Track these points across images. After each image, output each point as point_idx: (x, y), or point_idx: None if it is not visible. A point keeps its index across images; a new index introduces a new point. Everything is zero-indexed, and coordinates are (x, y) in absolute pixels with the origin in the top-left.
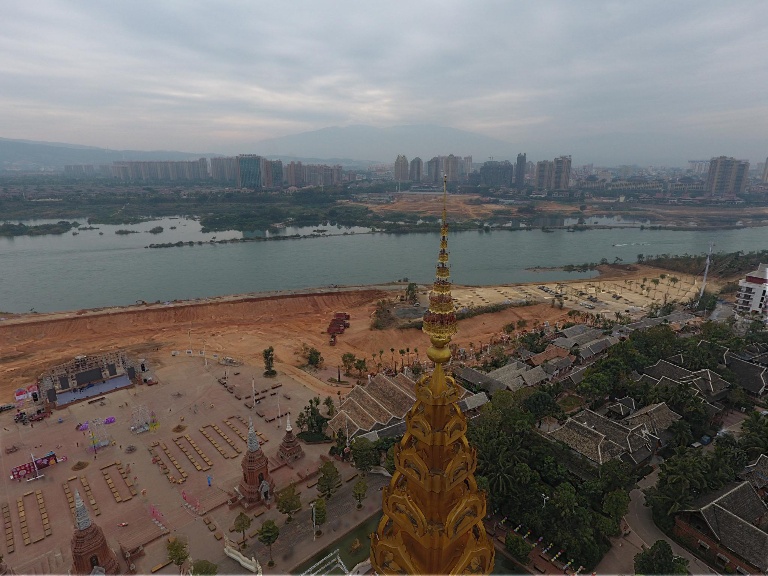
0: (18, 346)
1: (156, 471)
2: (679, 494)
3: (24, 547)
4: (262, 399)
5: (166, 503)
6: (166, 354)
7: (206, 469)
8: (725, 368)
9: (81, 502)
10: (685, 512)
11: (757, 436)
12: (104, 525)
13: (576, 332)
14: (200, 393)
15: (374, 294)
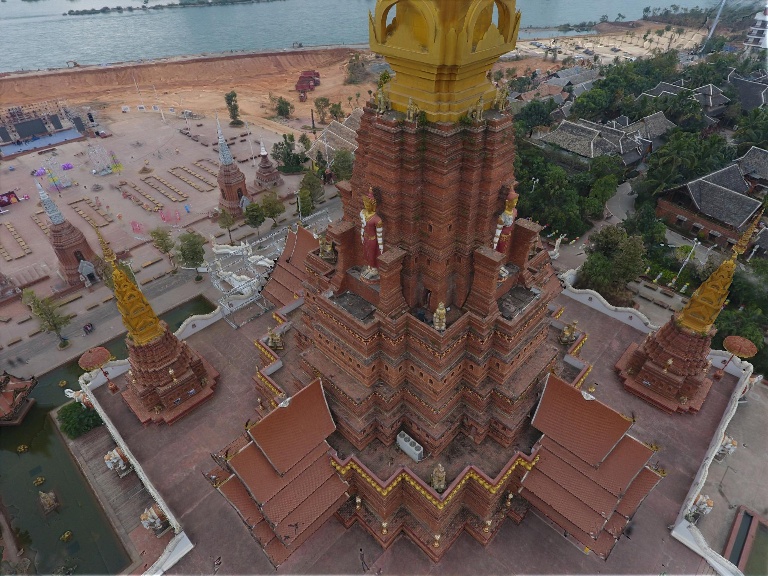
0: None
1: (129, 204)
2: (668, 174)
3: (6, 262)
4: (231, 145)
5: (146, 226)
6: (115, 111)
7: (182, 200)
8: (729, 83)
9: (46, 195)
10: (670, 191)
11: (752, 132)
12: None
13: (570, 73)
14: (162, 142)
15: (345, 53)
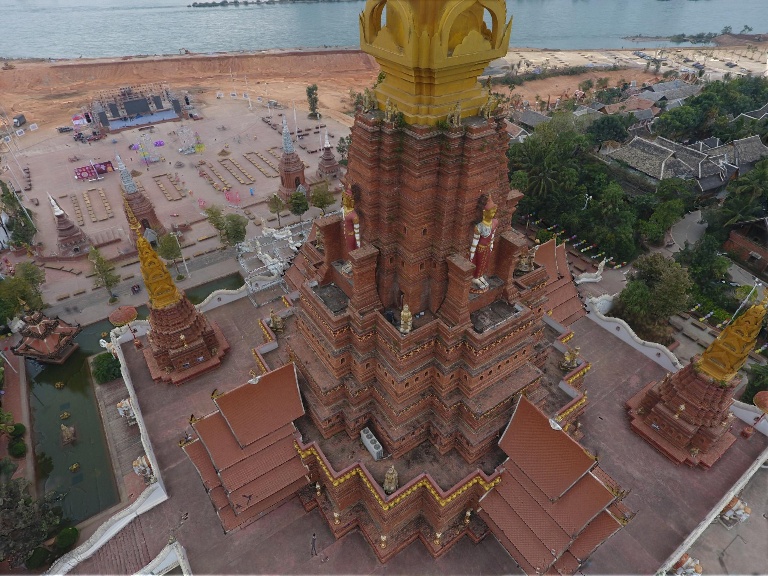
0: (71, 85)
1: (203, 182)
2: (745, 204)
3: (92, 223)
4: (305, 136)
5: None
6: (211, 96)
7: (249, 183)
8: None
9: (123, 166)
10: (745, 223)
11: None
12: (158, 214)
13: (668, 88)
14: (244, 128)
15: None
